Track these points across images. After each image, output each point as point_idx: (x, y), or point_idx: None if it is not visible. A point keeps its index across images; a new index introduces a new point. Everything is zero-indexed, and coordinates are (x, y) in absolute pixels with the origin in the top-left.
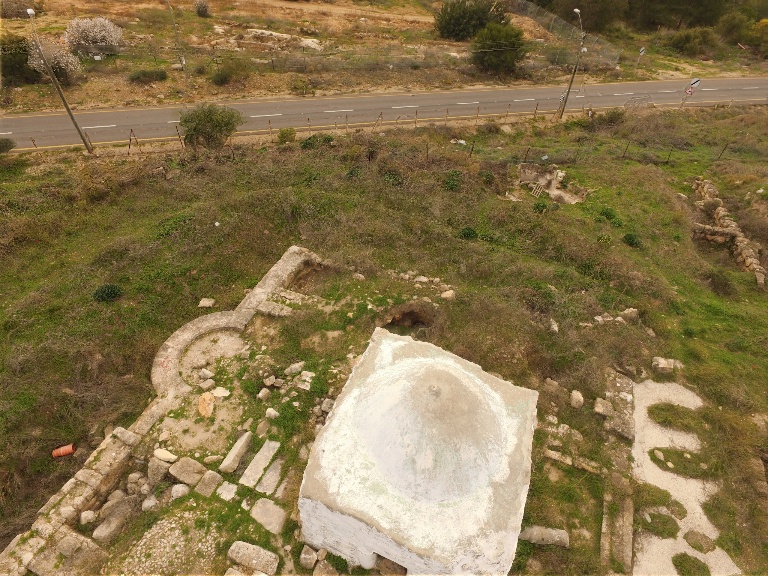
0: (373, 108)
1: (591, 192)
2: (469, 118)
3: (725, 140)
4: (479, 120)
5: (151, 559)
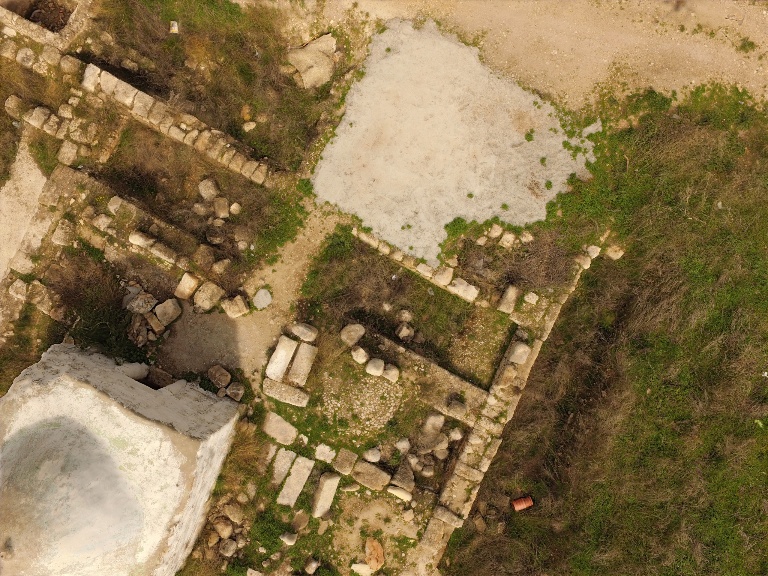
0: None
1: None
2: None
3: None
4: None
5: (379, 395)
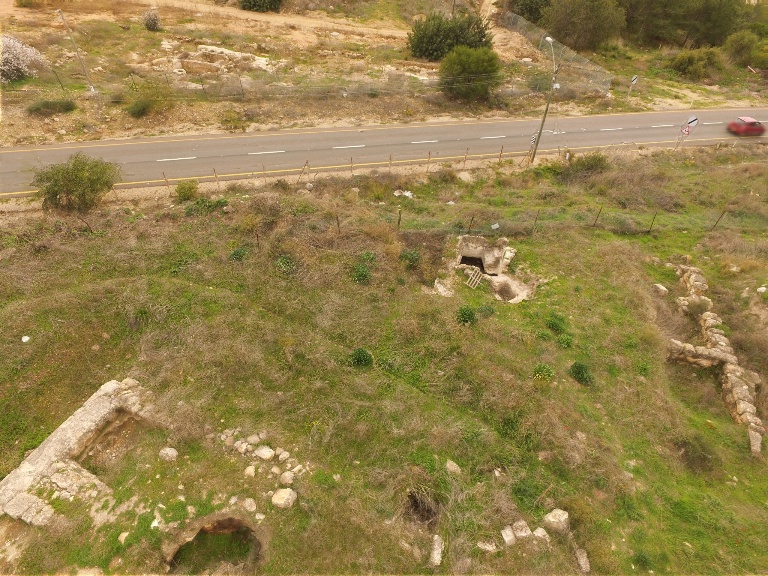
0: (309, 149)
1: (543, 284)
2: (421, 162)
3: (724, 199)
4: (433, 165)
5: None
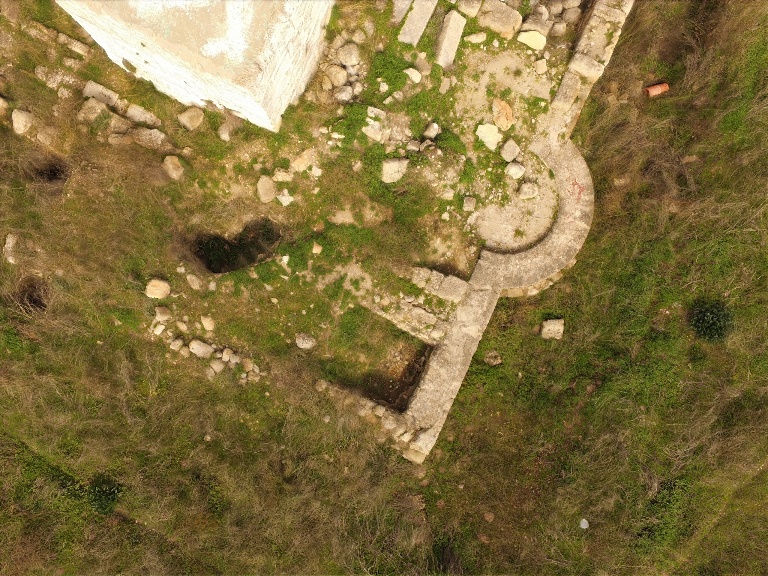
0: None
1: None
2: None
3: None
4: None
5: None
